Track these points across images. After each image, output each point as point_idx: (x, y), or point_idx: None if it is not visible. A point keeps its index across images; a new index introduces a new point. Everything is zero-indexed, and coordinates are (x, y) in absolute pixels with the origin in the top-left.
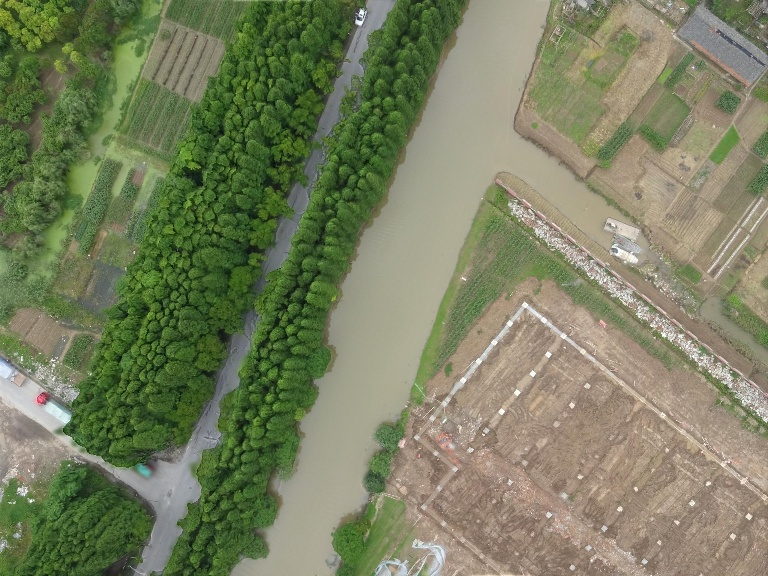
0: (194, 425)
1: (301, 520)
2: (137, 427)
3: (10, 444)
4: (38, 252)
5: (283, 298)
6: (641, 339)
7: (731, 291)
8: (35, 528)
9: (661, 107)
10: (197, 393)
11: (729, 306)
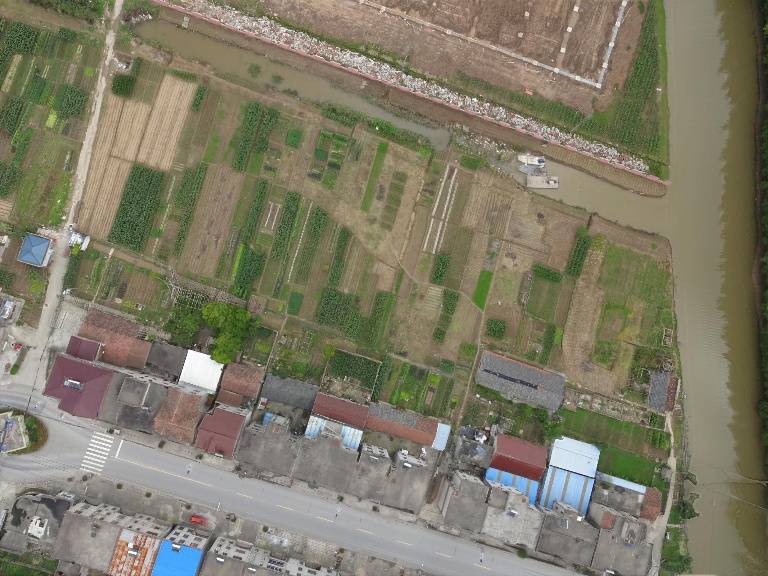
0: None
1: None
2: None
3: None
4: None
5: None
6: (493, 89)
7: (431, 160)
8: None
9: (551, 305)
10: None
11: (429, 145)
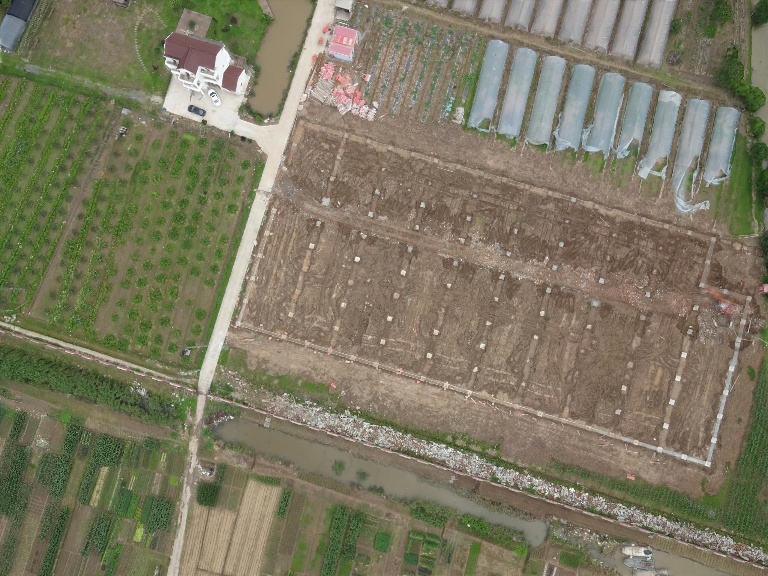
0: None
1: None
2: None
3: None
4: None
5: None
6: (591, 477)
7: (528, 558)
8: None
9: None
10: None
11: (525, 543)
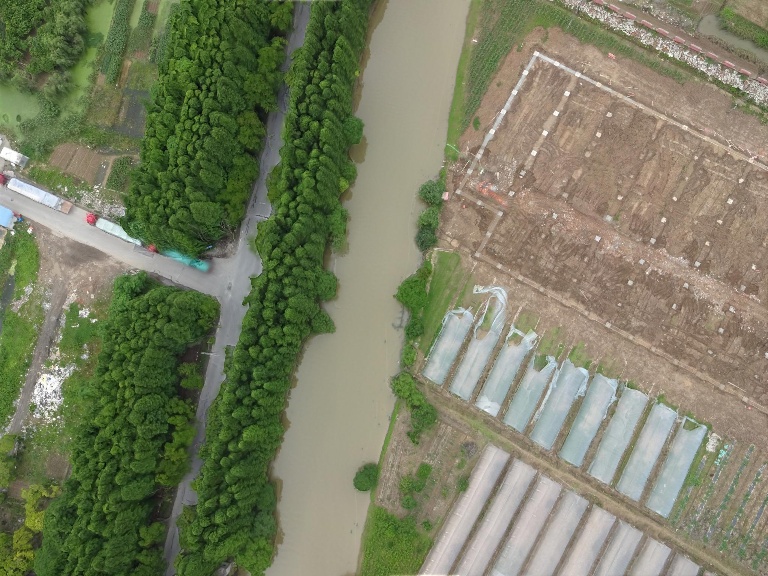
0: (245, 202)
1: (361, 297)
2: (193, 194)
3: (65, 271)
4: (68, 87)
5: (312, 58)
6: (650, 62)
7: (723, 6)
8: (104, 330)
9: None
10: (243, 170)
11: (724, 19)
